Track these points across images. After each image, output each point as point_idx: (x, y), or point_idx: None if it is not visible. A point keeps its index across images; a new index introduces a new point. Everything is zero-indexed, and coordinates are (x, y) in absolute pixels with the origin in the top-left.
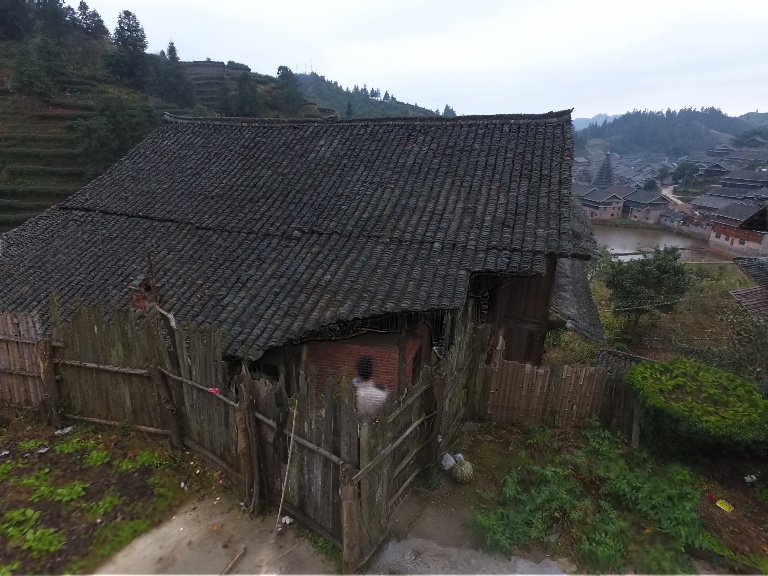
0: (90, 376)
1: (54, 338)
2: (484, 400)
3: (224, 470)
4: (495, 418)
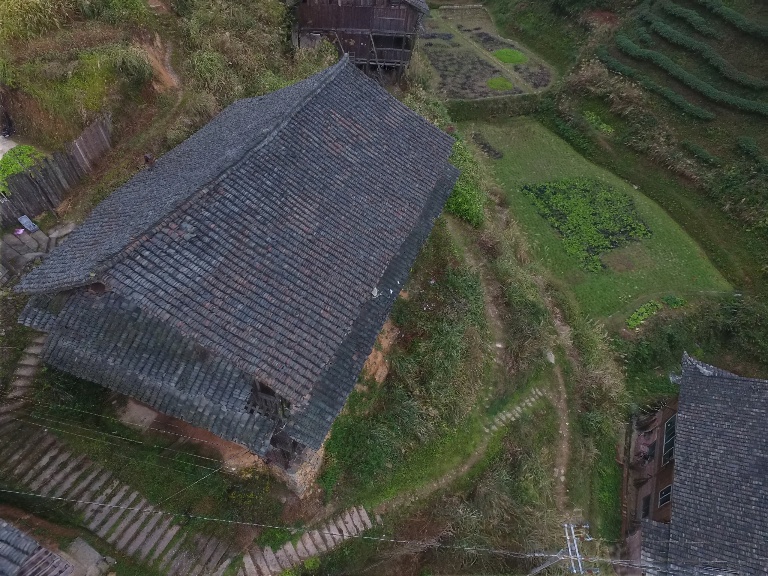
0: (67, 170)
1: (72, 154)
2: (2, 271)
3: (30, 214)
4: (4, 280)
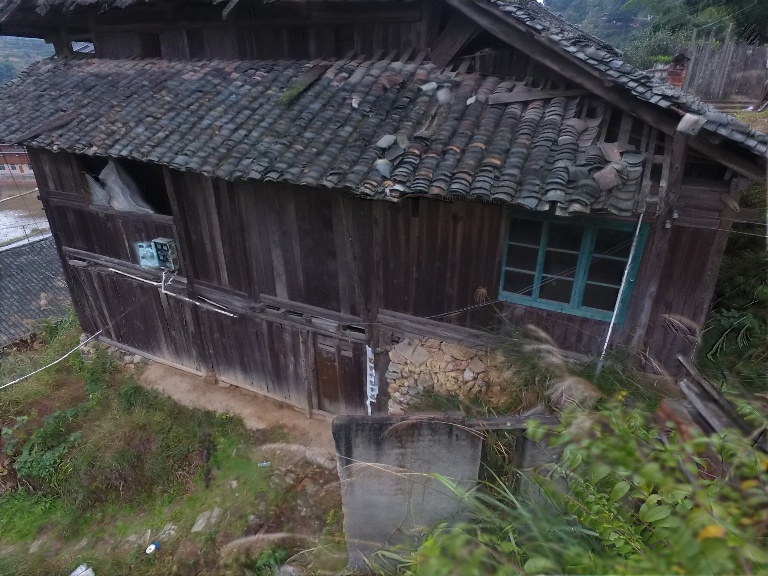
0: None
1: None
2: None
3: None
4: None
